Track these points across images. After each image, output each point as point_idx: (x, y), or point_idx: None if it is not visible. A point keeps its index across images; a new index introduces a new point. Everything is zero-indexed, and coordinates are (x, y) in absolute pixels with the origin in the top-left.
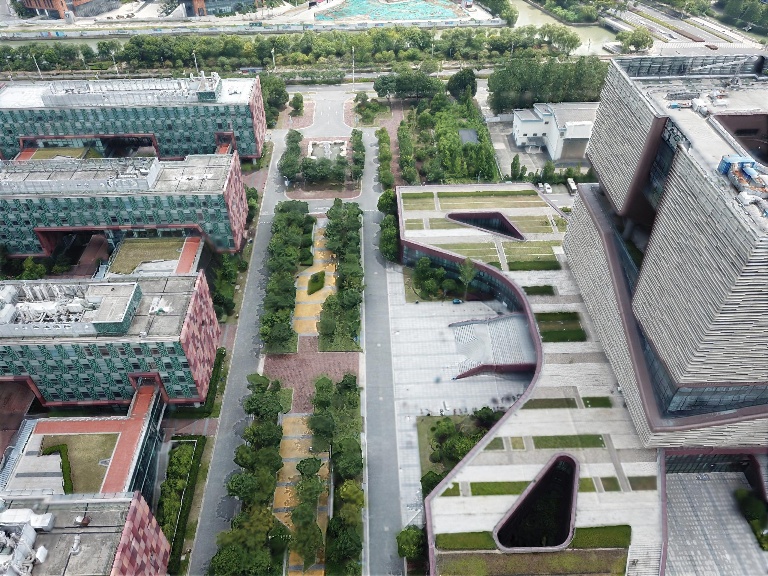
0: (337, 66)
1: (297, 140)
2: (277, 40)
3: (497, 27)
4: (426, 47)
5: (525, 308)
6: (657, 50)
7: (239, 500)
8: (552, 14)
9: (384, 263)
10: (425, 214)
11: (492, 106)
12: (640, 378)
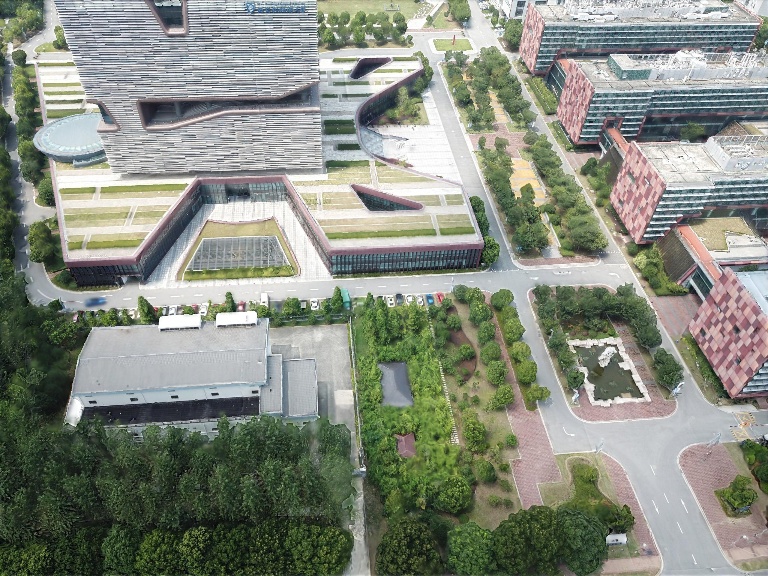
0: None
1: (658, 354)
2: None
3: None
4: None
5: None
6: None
7: None
8: None
9: None
10: (446, 210)
11: None
12: None
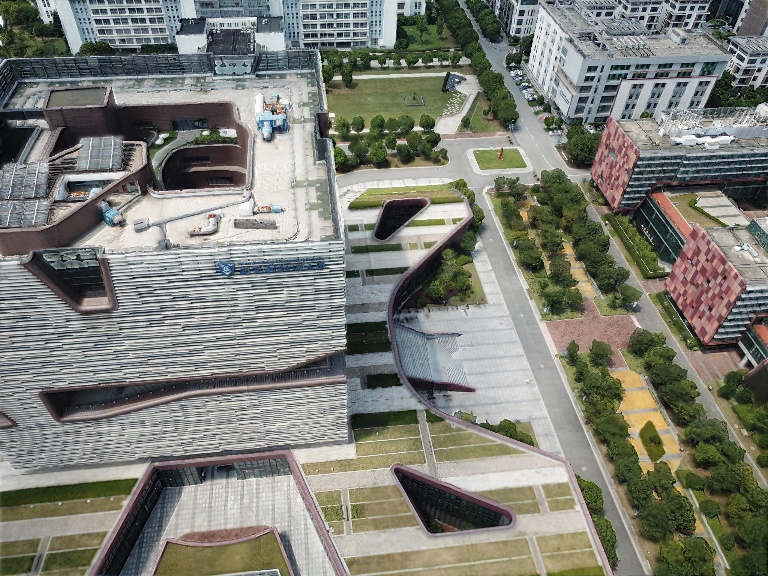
0: None
1: None
2: None
3: None
4: None
5: None
6: None
7: None
8: None
9: None
10: (550, 523)
11: None
12: None
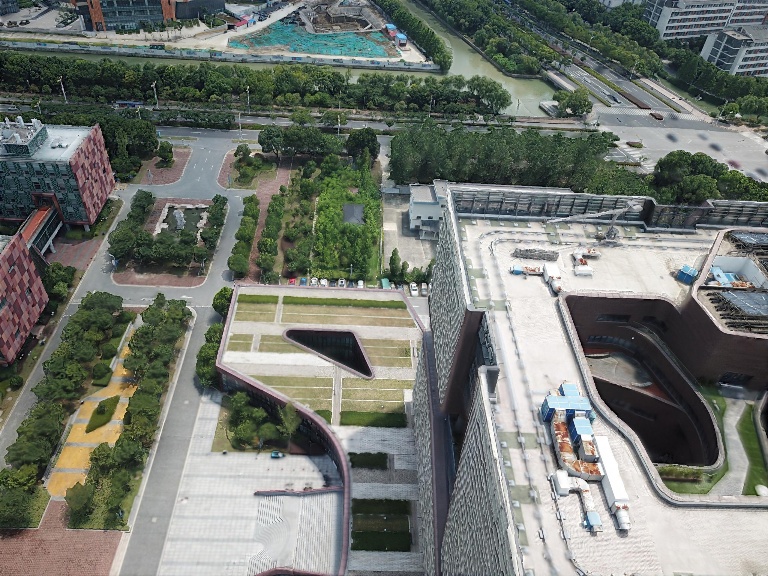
0: (230, 107)
1: (144, 204)
2: (165, 71)
3: (429, 72)
4: (337, 92)
5: None
6: (597, 115)
7: None
8: (492, 61)
9: (202, 387)
10: (259, 328)
11: (390, 175)
12: None
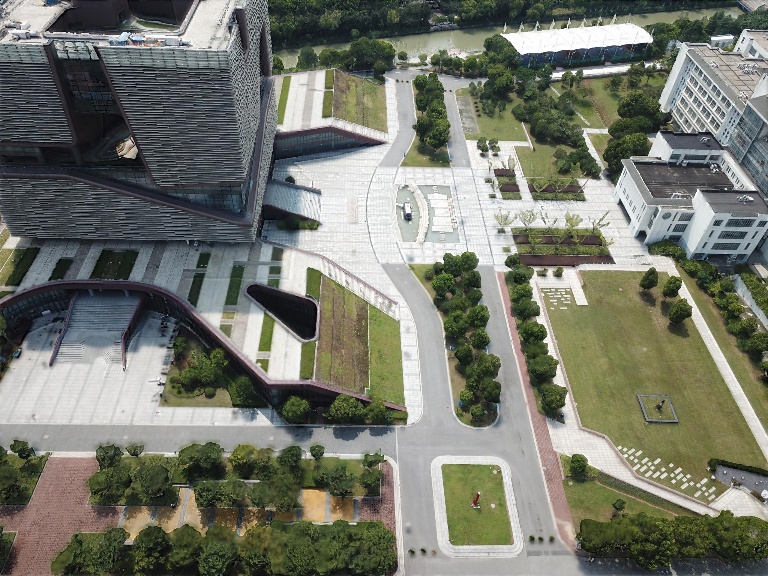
0: None
1: None
2: None
3: None
4: None
5: (79, 284)
6: None
7: (222, 575)
8: None
9: None
10: None
11: None
12: (211, 215)
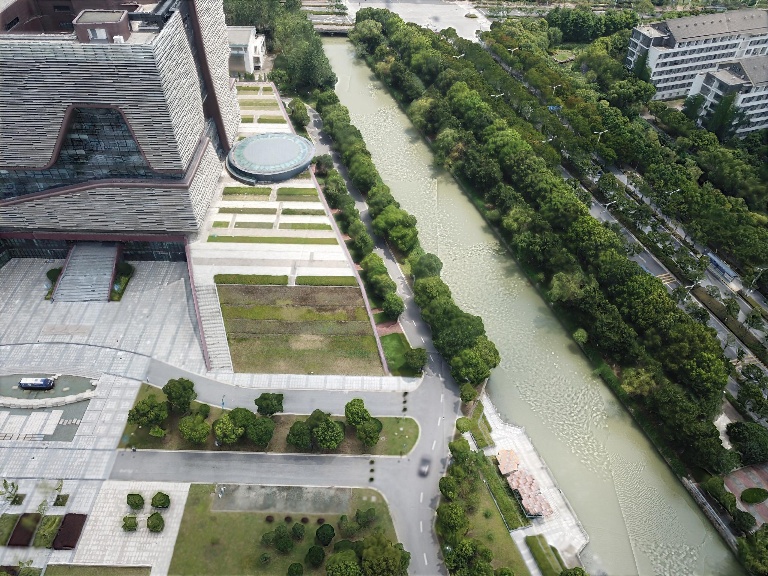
0: None
1: None
2: None
3: None
4: None
5: None
6: None
7: None
8: None
9: None
10: None
11: None
12: None
